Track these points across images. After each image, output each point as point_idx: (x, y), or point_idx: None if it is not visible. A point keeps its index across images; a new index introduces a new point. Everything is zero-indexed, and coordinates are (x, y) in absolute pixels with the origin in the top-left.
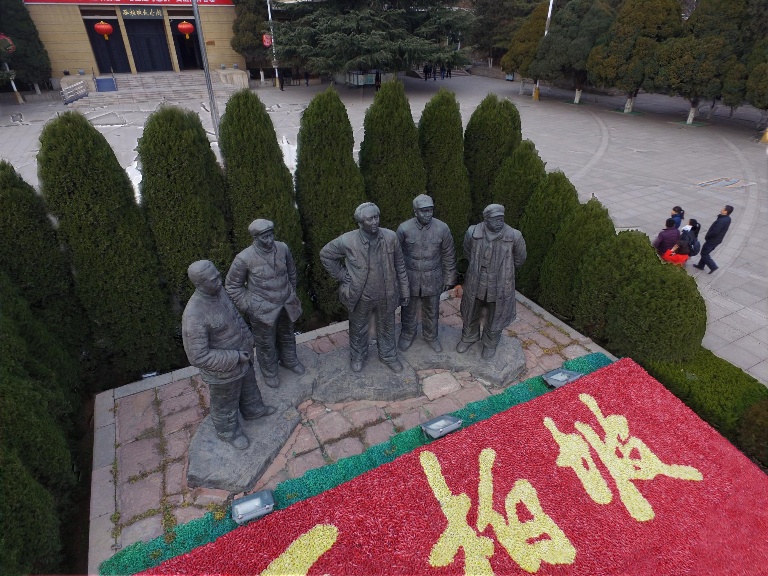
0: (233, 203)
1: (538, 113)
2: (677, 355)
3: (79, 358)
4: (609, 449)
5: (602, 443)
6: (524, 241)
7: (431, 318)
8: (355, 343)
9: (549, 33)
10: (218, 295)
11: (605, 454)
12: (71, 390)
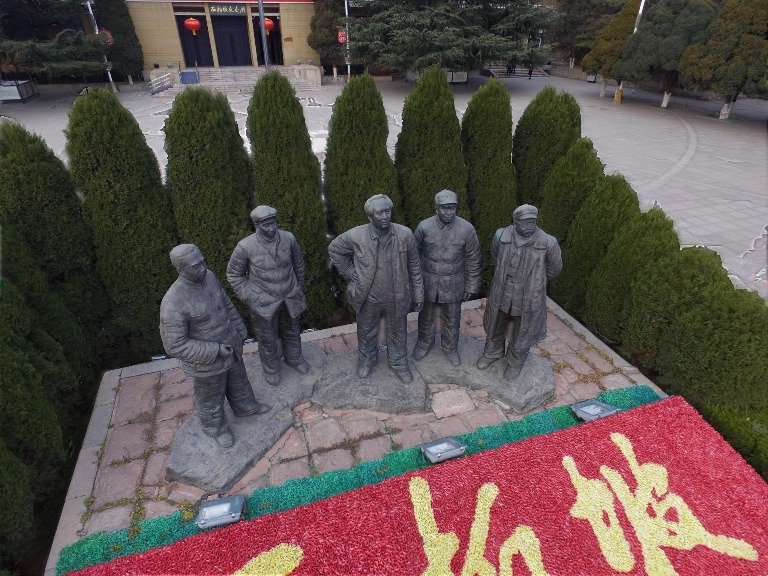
0: (257, 190)
1: (618, 116)
2: (743, 400)
3: (98, 334)
4: (639, 504)
5: (631, 496)
6: None
7: (449, 327)
8: (362, 347)
9: (638, 30)
10: (203, 282)
11: (633, 510)
12: (84, 364)
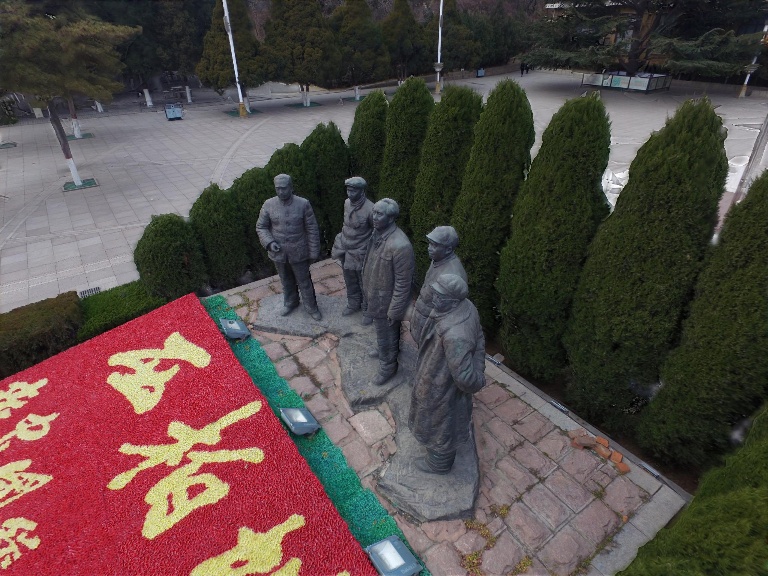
0: None
1: None
2: None
3: None
4: None
5: None
6: (461, 355)
7: None
8: None
9: None
10: (287, 202)
11: None
12: None
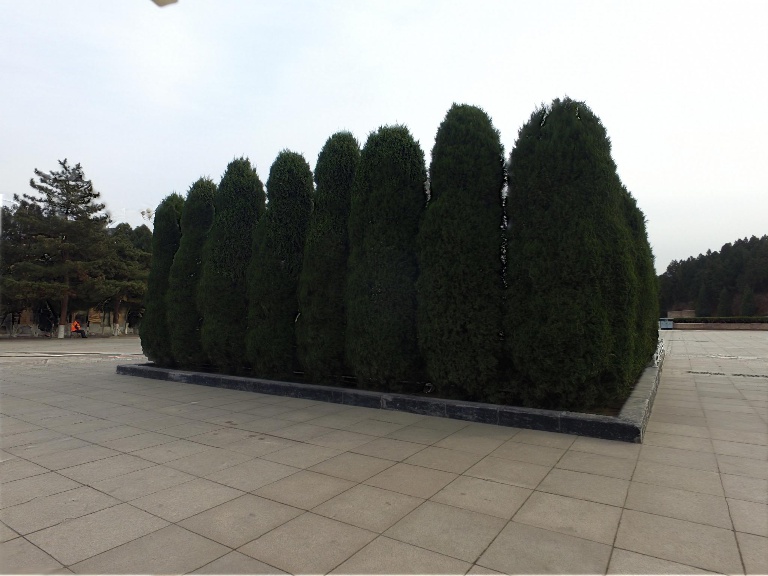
0: None
1: None
2: None
3: None
4: None
5: None
6: None
7: None
8: None
9: None
10: None
11: None
12: None
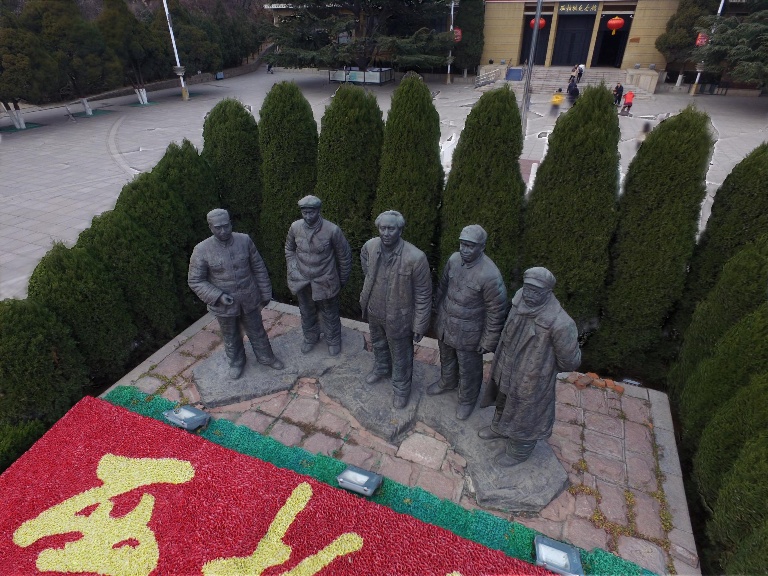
0: (380, 184)
1: None
2: None
3: None
4: None
5: None
6: (575, 338)
7: (460, 375)
8: (374, 354)
9: None
10: (228, 242)
11: None
12: None
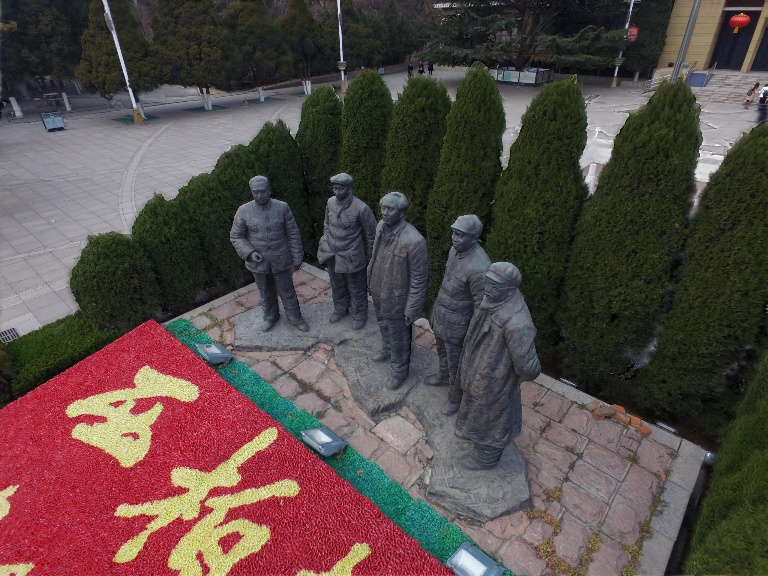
0: None
1: None
2: None
3: None
4: None
5: None
6: (528, 343)
7: None
8: None
9: None
10: (266, 207)
11: None
12: None
